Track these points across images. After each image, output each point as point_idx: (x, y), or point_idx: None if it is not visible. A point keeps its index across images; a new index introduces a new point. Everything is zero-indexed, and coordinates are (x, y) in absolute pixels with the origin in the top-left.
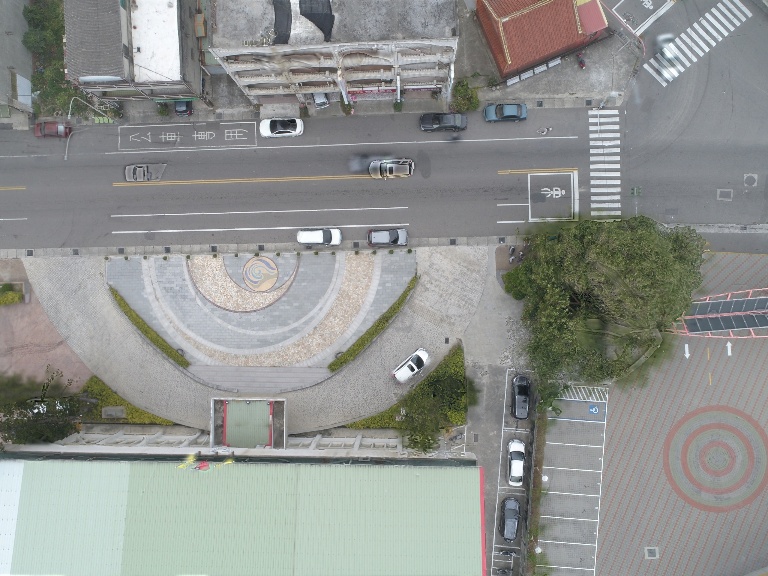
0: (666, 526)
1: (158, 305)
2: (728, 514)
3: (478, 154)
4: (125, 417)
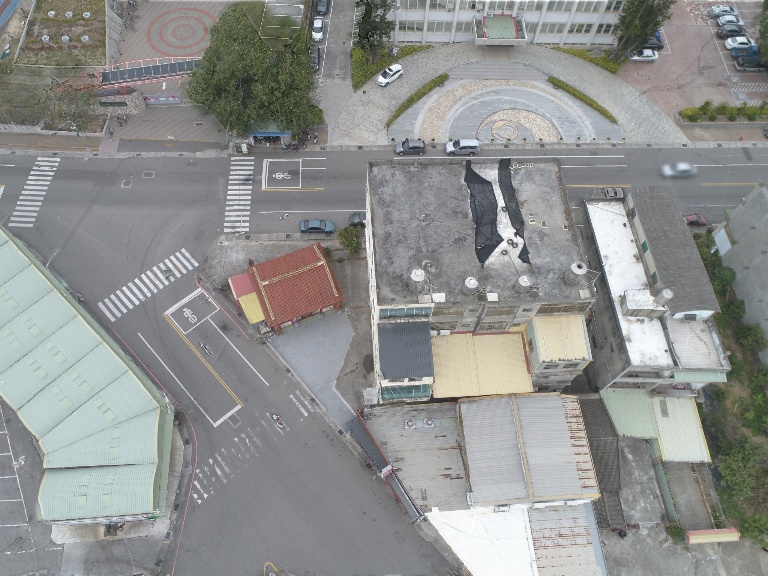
0: (222, 2)
1: (578, 114)
2: (182, 7)
3: (340, 202)
4: (587, 52)
